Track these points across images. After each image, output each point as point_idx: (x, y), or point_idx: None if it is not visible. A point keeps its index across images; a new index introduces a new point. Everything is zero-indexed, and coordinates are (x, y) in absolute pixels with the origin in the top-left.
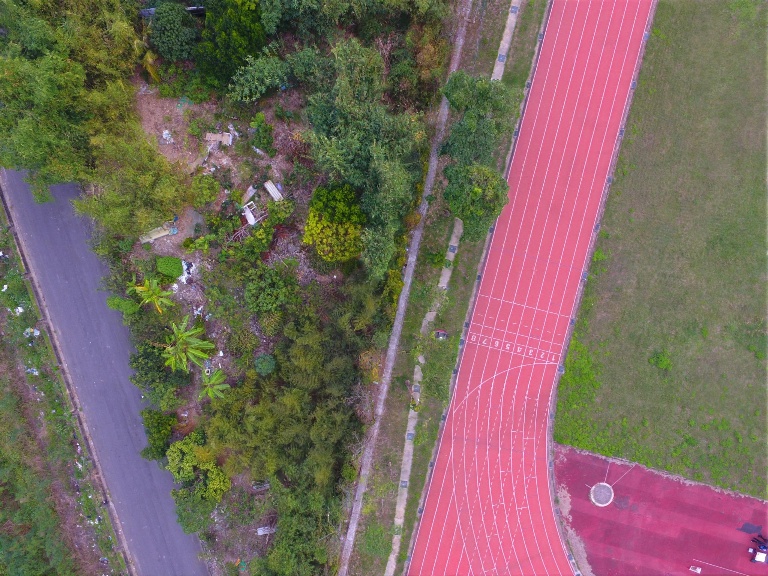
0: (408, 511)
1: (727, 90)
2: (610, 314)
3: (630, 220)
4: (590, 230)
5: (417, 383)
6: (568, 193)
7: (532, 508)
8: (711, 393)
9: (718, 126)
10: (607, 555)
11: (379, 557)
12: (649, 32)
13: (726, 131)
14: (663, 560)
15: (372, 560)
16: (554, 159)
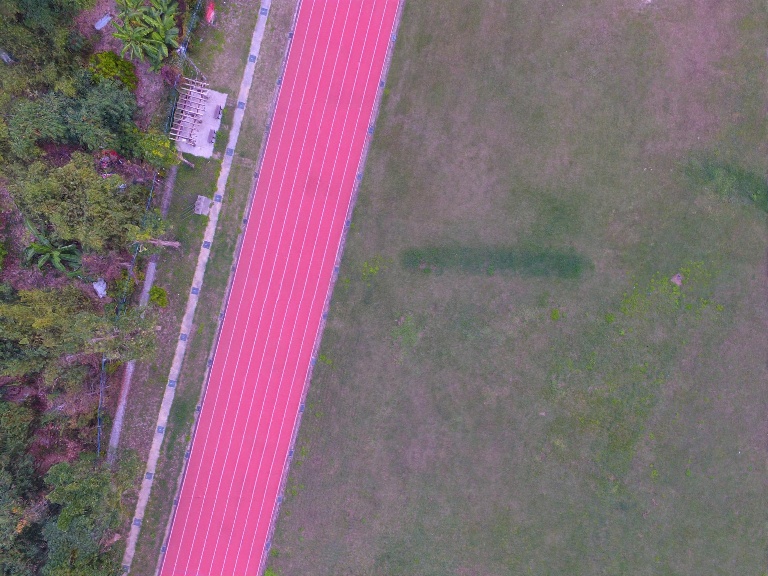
0: None
1: (391, 413)
2: None
3: (299, 539)
4: (261, 548)
5: None
6: (239, 513)
7: None
8: None
9: (383, 448)
10: None
11: None
12: (316, 357)
13: (391, 452)
14: None
15: None
16: (225, 480)
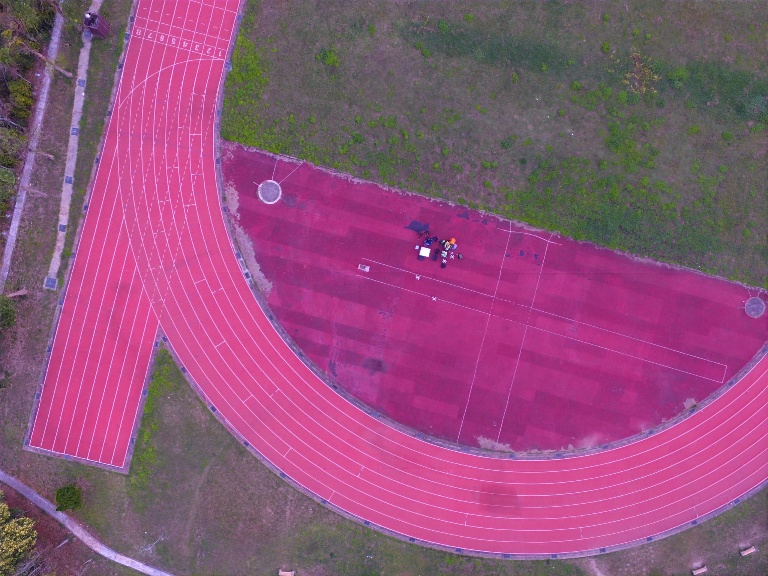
0: (73, 207)
1: None
2: (277, 10)
3: None
4: None
5: (81, 77)
6: None
7: (199, 205)
8: (378, 90)
9: None
10: (275, 253)
11: (43, 253)
12: None
13: None
14: (331, 259)
15: (35, 256)
16: None
